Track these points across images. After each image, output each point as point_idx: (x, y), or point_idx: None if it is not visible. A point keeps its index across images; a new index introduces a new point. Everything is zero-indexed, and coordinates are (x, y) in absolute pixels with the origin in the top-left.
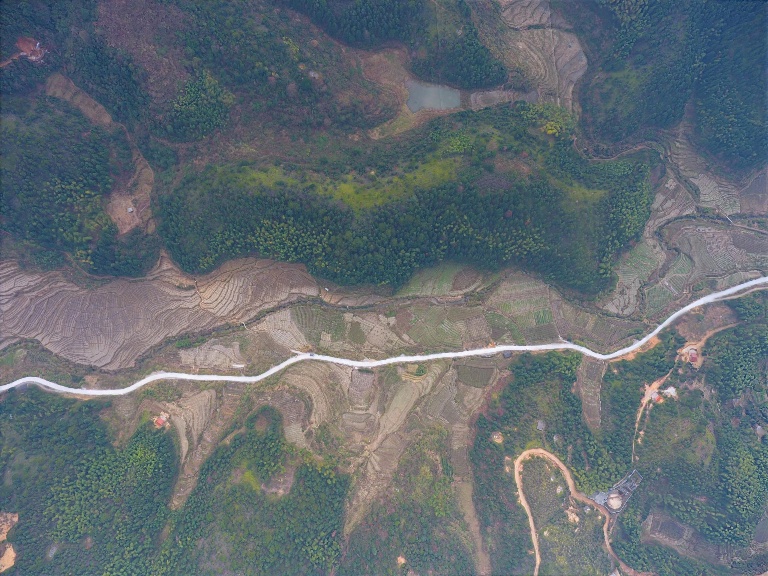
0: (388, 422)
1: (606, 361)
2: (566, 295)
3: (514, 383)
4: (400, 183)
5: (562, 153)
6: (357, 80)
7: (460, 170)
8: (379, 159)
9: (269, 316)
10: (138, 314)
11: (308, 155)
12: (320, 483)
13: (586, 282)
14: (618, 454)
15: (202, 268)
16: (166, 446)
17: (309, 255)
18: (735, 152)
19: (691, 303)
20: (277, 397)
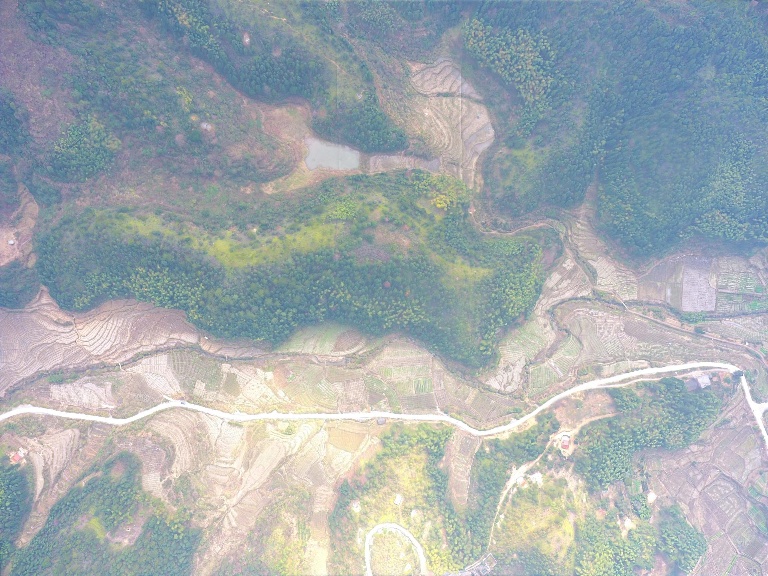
0: (250, 479)
1: (481, 437)
2: (449, 366)
3: (380, 453)
4: (279, 244)
5: (449, 228)
6: (254, 133)
7: (339, 237)
8: (265, 216)
9: (145, 359)
10: (13, 345)
11: (192, 206)
12: (167, 537)
13: (467, 357)
14: (477, 535)
15: (77, 307)
16: (17, 484)
17: (186, 305)
18: (631, 241)
19: (573, 387)
20: (139, 444)
